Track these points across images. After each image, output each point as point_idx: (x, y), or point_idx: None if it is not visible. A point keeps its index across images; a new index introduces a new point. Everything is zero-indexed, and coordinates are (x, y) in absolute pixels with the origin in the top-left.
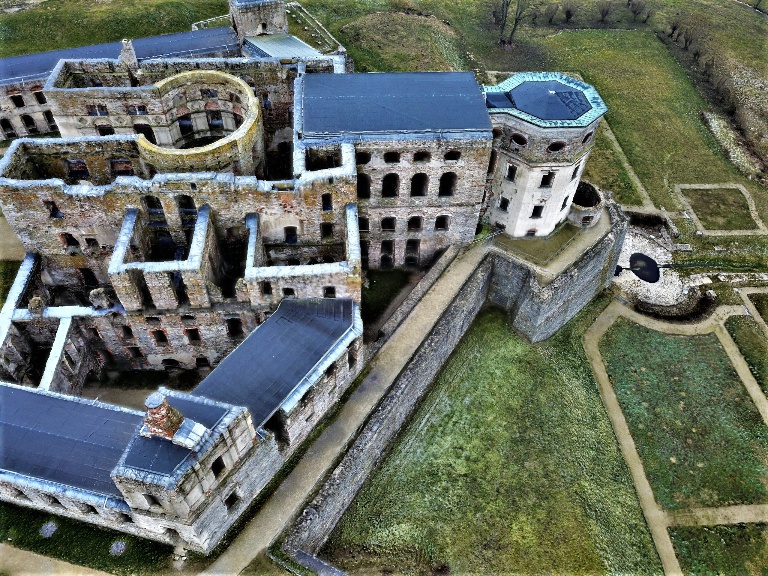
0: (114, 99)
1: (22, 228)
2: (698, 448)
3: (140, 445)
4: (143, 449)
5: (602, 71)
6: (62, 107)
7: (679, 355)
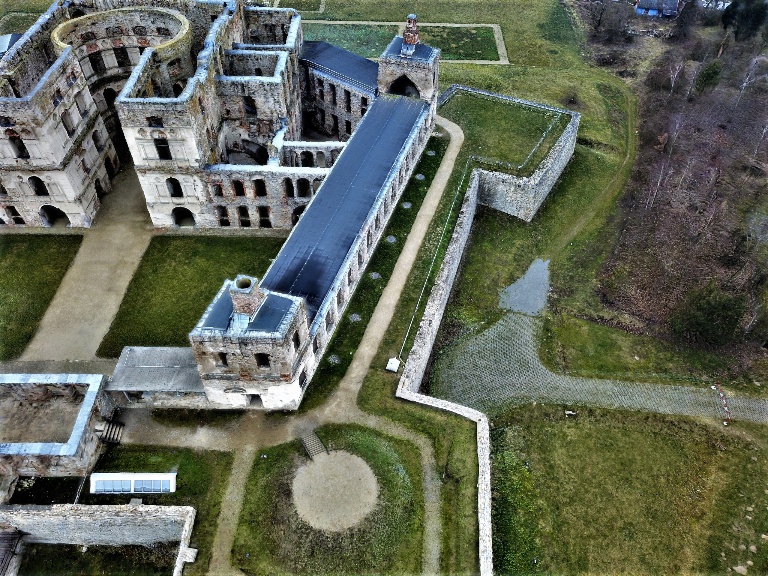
0: (60, 76)
1: (198, 141)
2: (369, 42)
3: (417, 55)
4: (420, 54)
5: (18, 3)
6: (42, 111)
7: (313, 35)
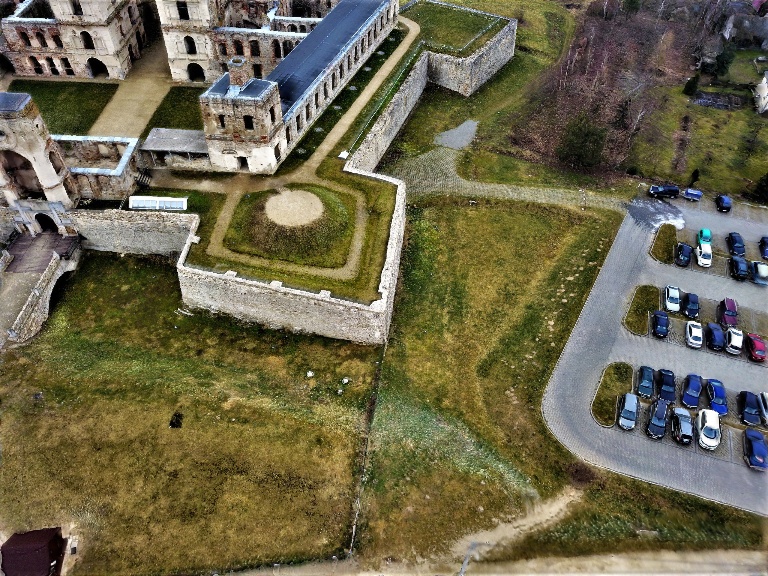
0: None
1: (209, 5)
2: None
3: None
4: None
5: None
6: None
7: None
